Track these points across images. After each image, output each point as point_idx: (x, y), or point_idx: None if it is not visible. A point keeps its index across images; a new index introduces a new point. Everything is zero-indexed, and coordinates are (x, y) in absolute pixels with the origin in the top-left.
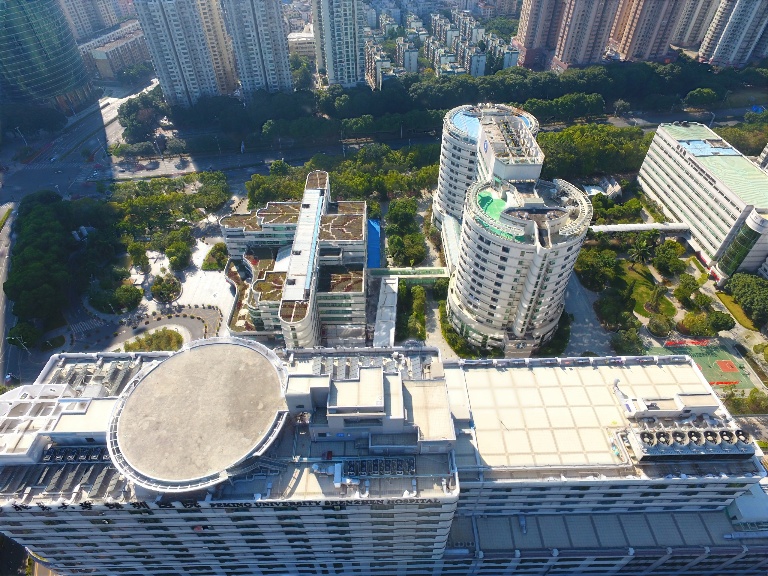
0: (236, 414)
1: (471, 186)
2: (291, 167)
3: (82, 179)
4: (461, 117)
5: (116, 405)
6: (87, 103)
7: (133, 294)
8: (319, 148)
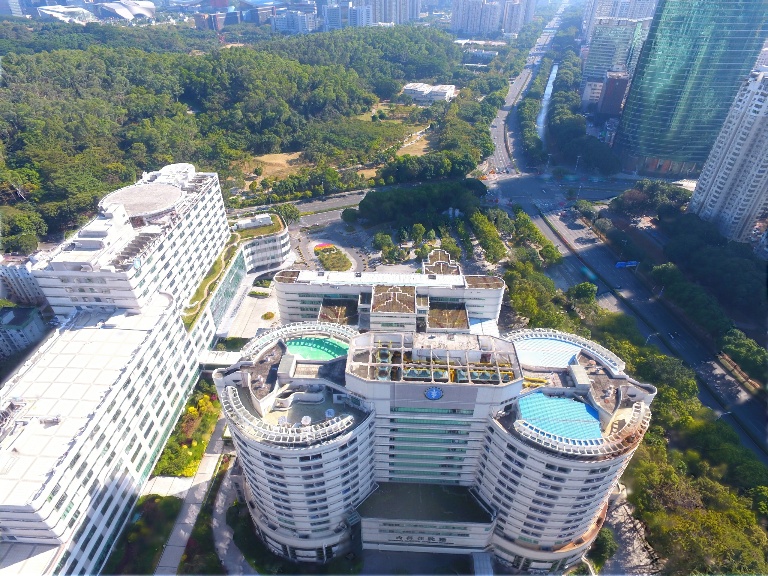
0: (129, 205)
1: (351, 329)
2: (592, 299)
3: (538, 202)
4: (567, 349)
5: (161, 182)
6: (672, 176)
7: (379, 241)
8: (686, 332)
